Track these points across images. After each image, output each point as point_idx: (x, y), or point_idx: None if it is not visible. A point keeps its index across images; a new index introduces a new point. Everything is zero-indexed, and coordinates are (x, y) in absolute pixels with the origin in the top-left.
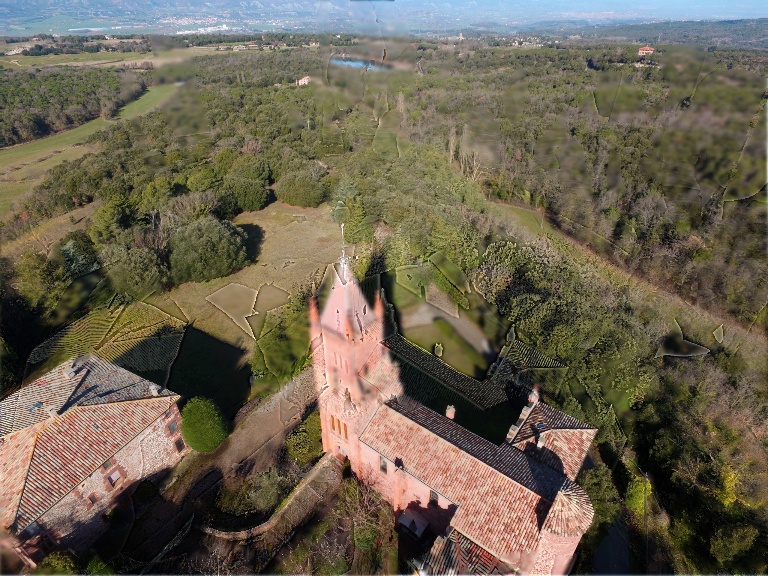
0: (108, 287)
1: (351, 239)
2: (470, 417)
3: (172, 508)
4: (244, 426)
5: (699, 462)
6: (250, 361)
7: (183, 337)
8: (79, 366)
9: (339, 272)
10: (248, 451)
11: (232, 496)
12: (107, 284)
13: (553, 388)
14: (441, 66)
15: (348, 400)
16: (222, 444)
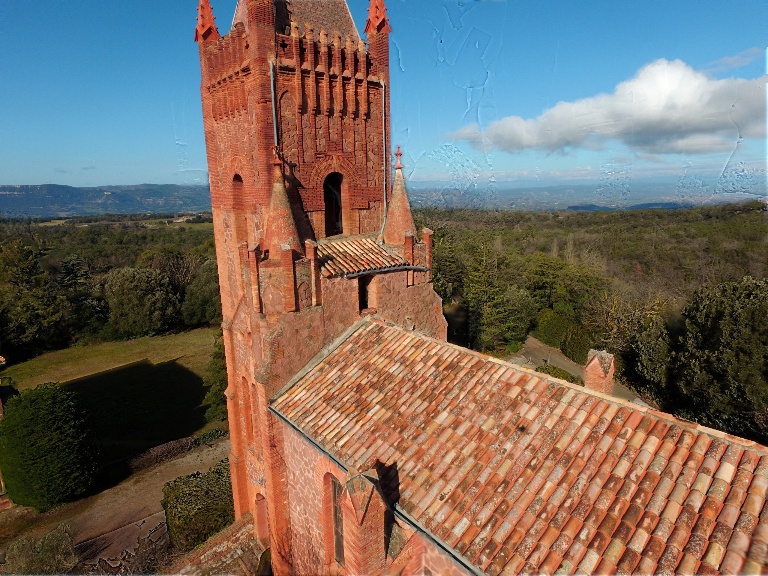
0: None
1: None
2: None
3: None
4: (142, 478)
5: None
6: None
7: (154, 369)
8: None
9: None
10: (113, 522)
11: None
12: None
13: None
14: (540, 83)
15: None
16: (79, 503)
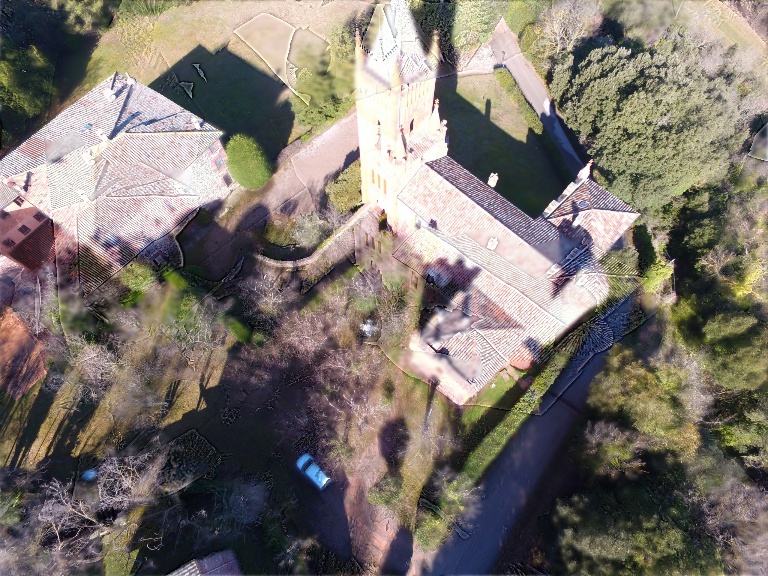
0: (105, 61)
1: None
2: (512, 251)
3: (227, 234)
4: (287, 167)
5: (731, 255)
6: (290, 99)
7: (218, 62)
8: (97, 154)
9: (389, 17)
10: (291, 192)
11: (279, 230)
12: (103, 56)
13: (614, 233)
14: None
15: (384, 221)
16: (267, 182)
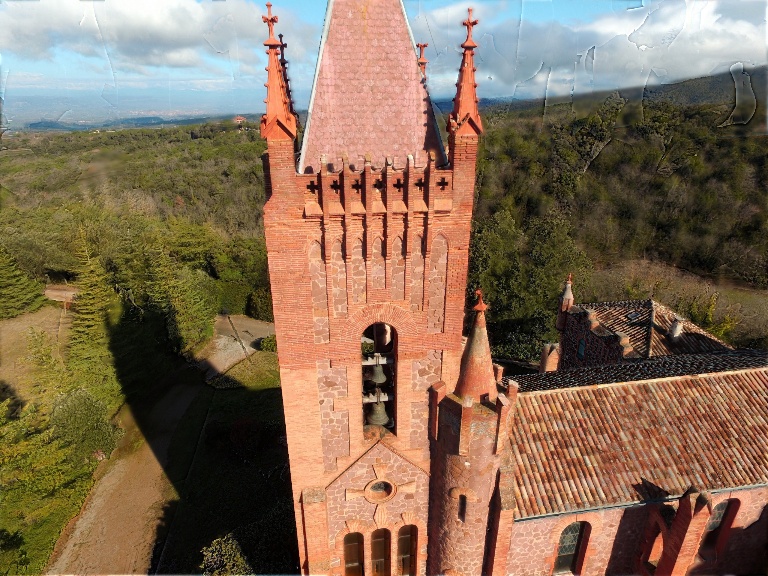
0: None
1: (1, 312)
2: None
3: None
4: None
5: None
6: None
7: None
8: None
9: None
10: None
11: None
12: None
13: None
14: None
15: None
16: None
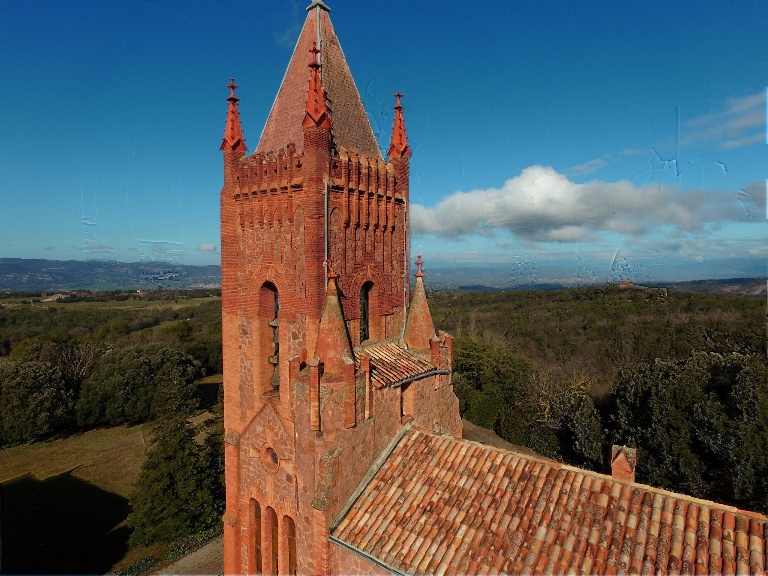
0: None
1: None
2: None
3: None
4: None
5: None
6: None
7: (42, 486)
8: None
9: None
10: None
11: None
12: None
13: None
14: (451, 183)
15: None
16: None
